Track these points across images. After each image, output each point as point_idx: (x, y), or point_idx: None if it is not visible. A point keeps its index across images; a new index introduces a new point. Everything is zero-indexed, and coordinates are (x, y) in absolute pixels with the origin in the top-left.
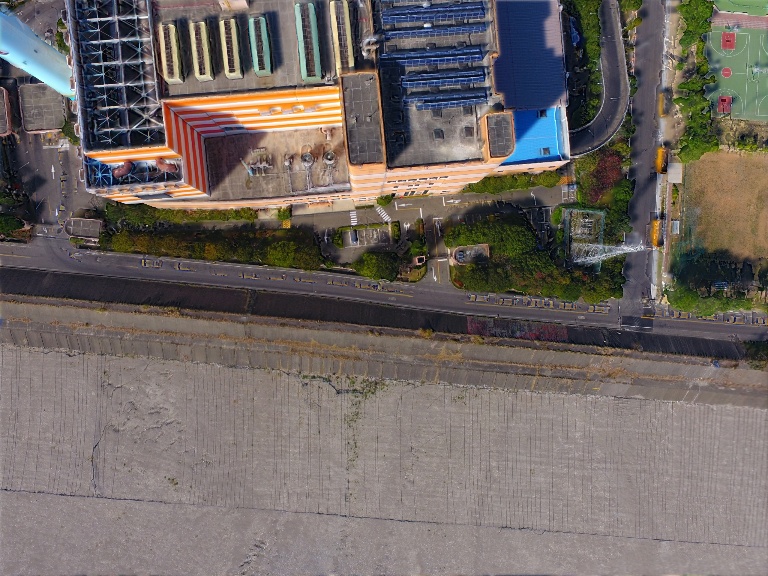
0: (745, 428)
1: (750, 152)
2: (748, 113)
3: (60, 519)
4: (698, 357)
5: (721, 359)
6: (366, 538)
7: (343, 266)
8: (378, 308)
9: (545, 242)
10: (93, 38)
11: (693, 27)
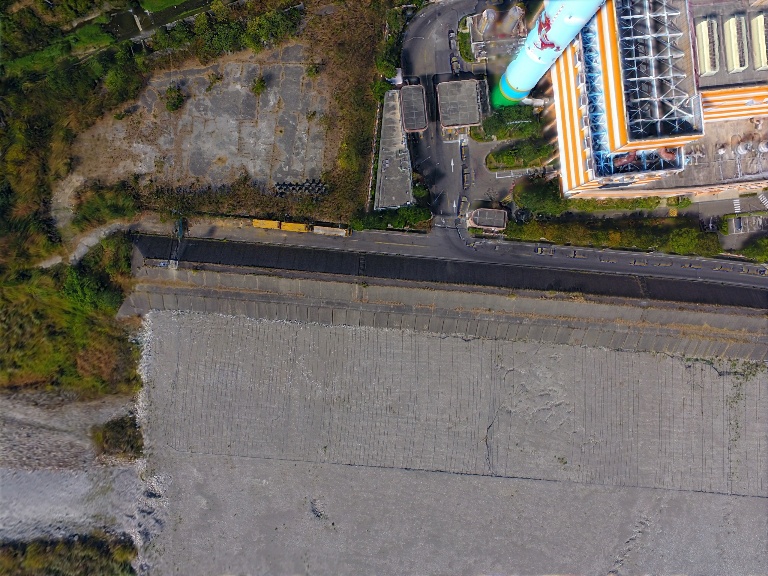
0: None
1: None
2: None
3: (457, 497)
4: None
5: None
6: (748, 516)
7: (730, 252)
8: (763, 292)
9: None
10: (626, 34)
11: None
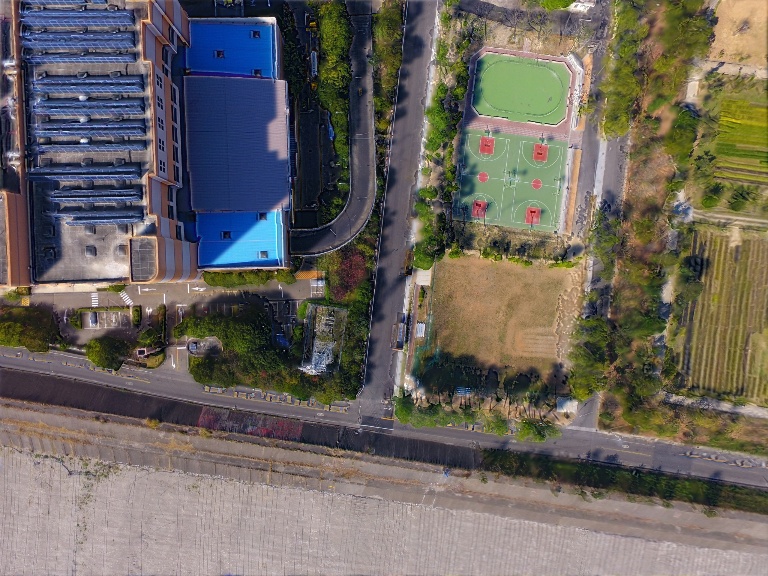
0: (484, 535)
1: (502, 259)
2: (503, 219)
3: None
4: (430, 464)
5: (453, 468)
6: None
7: (79, 348)
8: (113, 392)
9: (290, 336)
10: None
11: (435, 134)
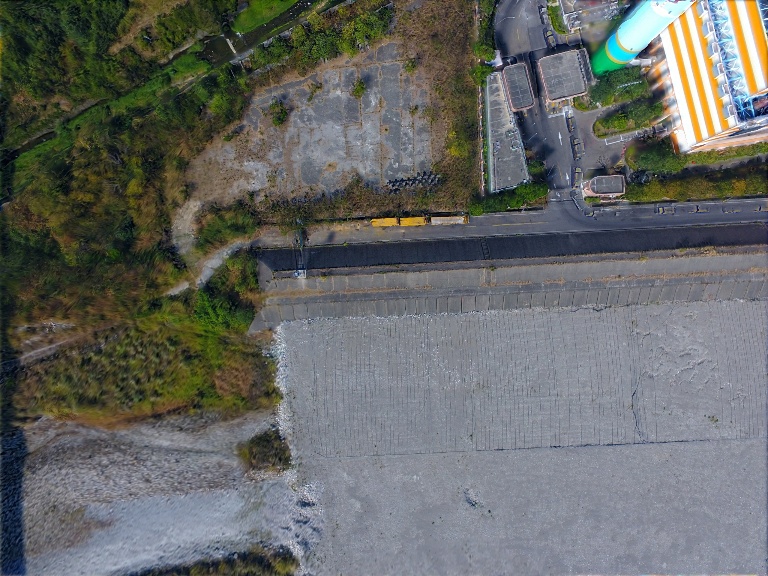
0: None
1: None
2: None
3: (610, 468)
4: None
5: None
6: None
7: None
8: None
9: None
10: None
11: None
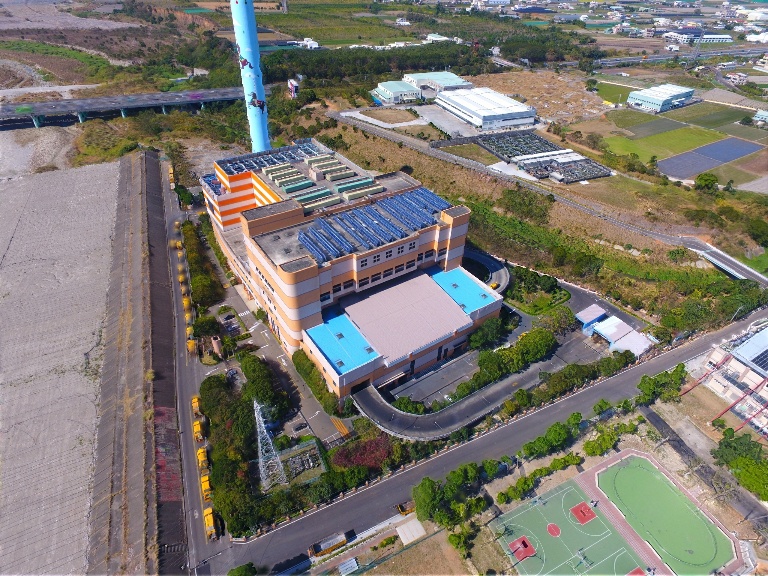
0: None
1: None
2: None
3: None
4: None
5: None
6: None
7: None
8: (171, 348)
9: None
10: None
11: None
